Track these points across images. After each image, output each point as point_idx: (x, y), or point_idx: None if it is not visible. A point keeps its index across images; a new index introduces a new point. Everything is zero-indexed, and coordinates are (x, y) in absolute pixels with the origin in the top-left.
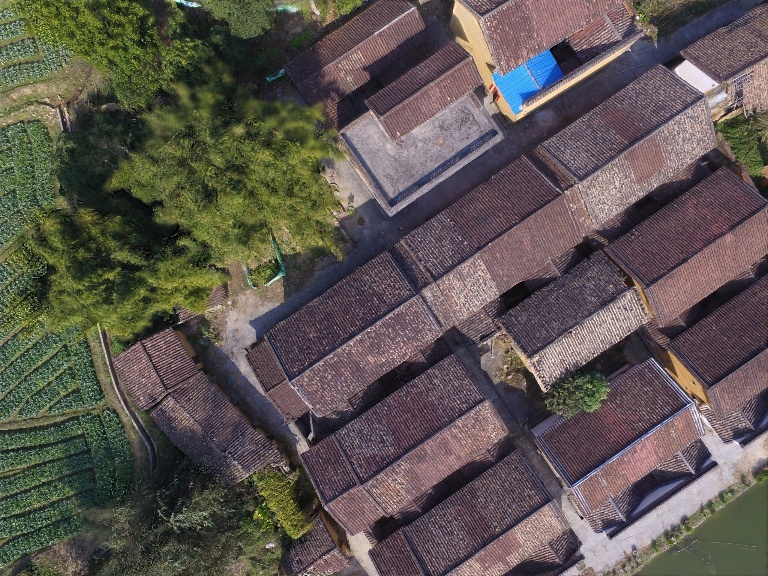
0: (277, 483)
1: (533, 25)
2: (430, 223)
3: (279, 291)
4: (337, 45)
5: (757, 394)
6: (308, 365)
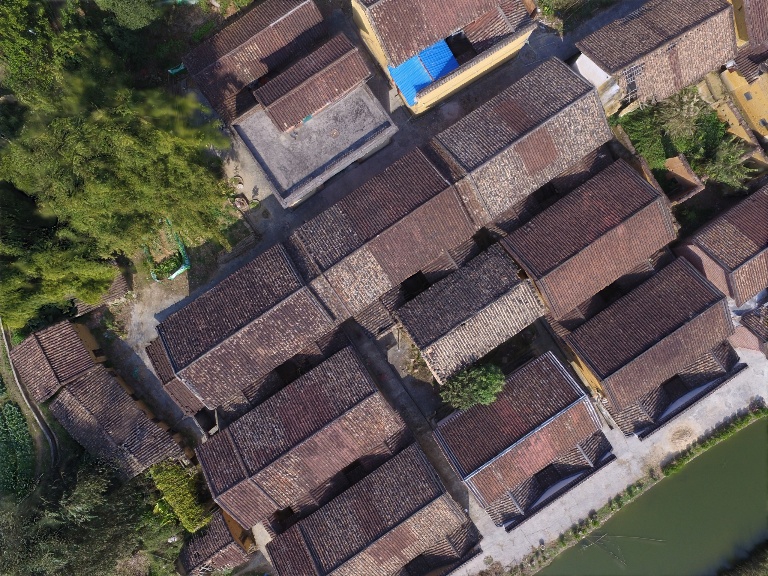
0: (175, 476)
1: (422, 16)
2: (323, 215)
3: (184, 284)
4: (234, 37)
5: (660, 387)
6: (195, 357)
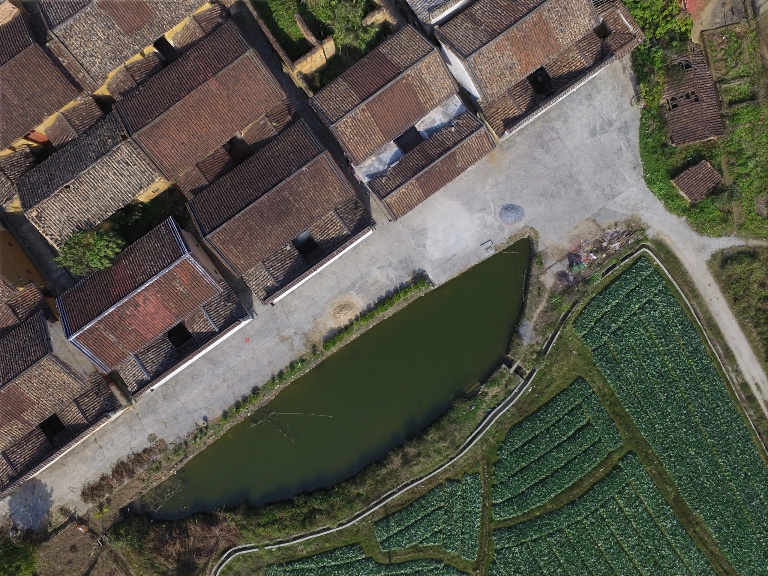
0: None
1: None
2: None
3: None
4: None
5: (297, 255)
6: None
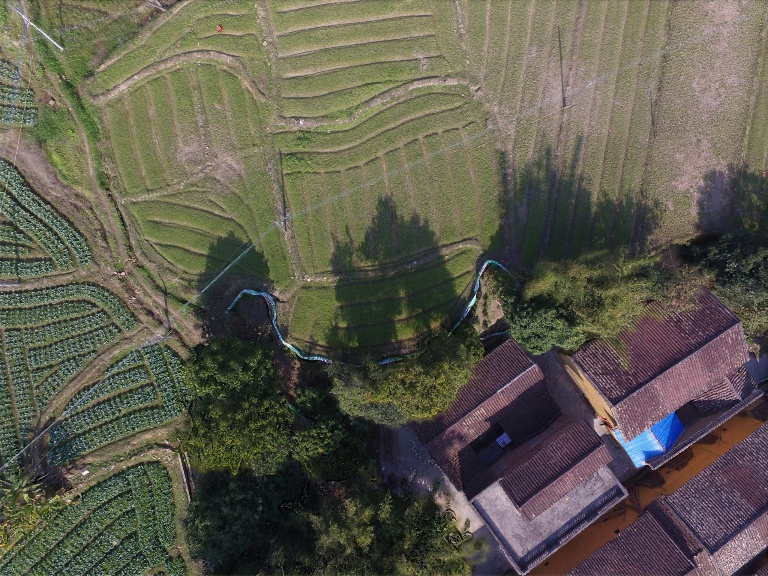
0: None
1: (659, 400)
2: None
3: None
4: (459, 399)
5: None
6: None
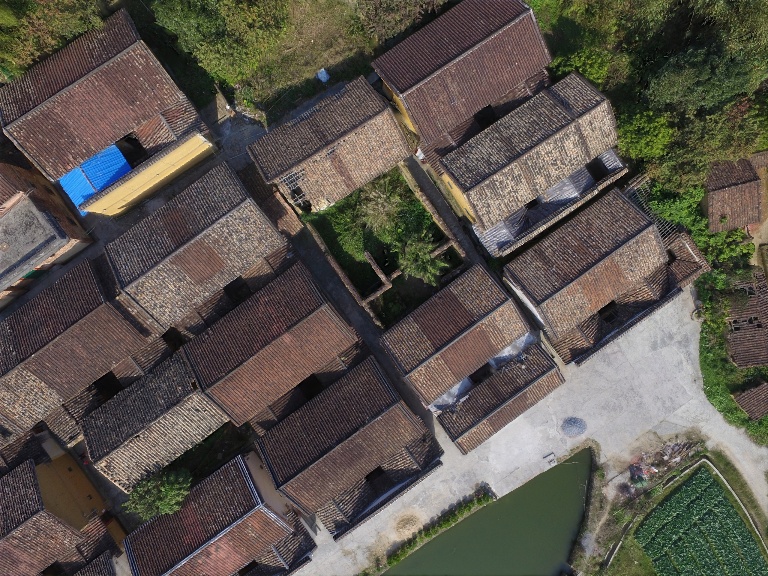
0: None
1: (71, 131)
2: None
3: None
4: None
5: (365, 483)
6: None
